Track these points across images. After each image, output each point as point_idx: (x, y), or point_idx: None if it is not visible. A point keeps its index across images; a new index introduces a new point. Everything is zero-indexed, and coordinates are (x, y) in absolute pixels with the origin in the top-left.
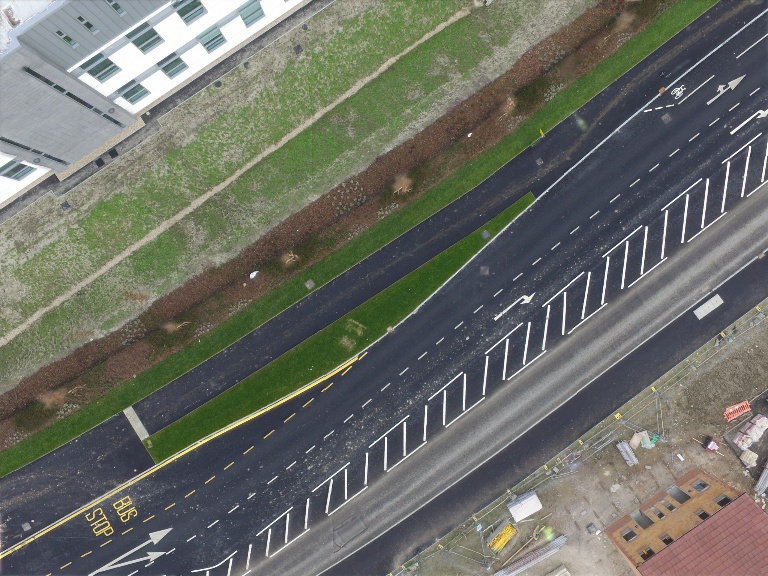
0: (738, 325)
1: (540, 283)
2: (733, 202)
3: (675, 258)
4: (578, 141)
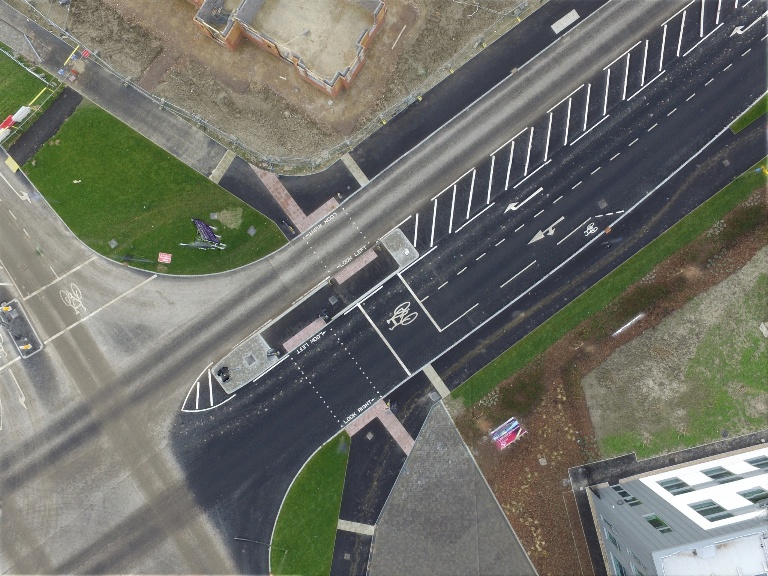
0: (538, 4)
1: (725, 46)
2: (541, 122)
3: (596, 69)
4: (689, 182)
